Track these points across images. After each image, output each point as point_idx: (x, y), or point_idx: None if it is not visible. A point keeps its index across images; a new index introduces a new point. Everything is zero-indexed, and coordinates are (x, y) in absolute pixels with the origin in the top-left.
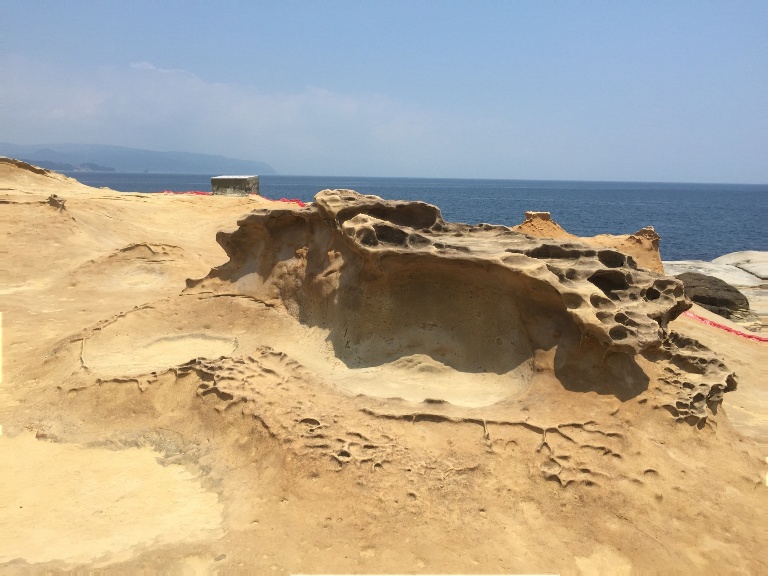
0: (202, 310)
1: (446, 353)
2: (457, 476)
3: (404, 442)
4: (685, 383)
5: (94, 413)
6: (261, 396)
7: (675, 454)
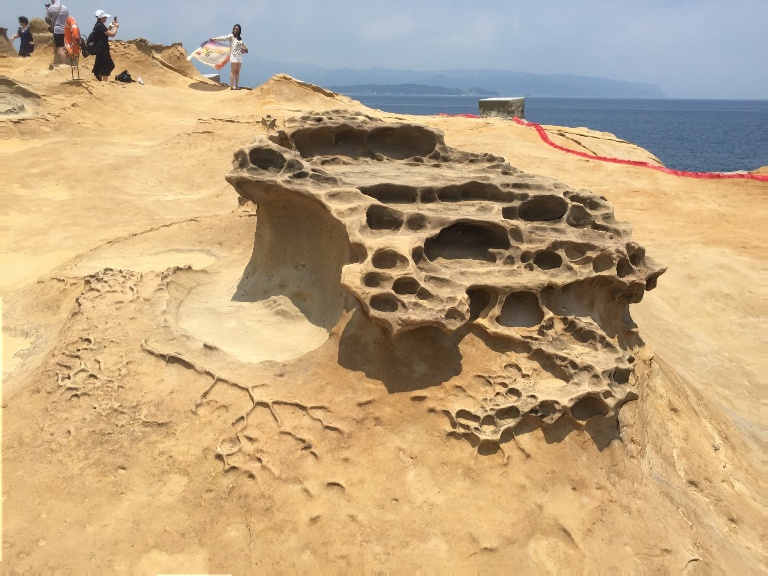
0: (230, 227)
1: (306, 299)
2: (140, 427)
3: (133, 380)
4: (513, 389)
5: (30, 303)
6: (93, 310)
7: (418, 476)
